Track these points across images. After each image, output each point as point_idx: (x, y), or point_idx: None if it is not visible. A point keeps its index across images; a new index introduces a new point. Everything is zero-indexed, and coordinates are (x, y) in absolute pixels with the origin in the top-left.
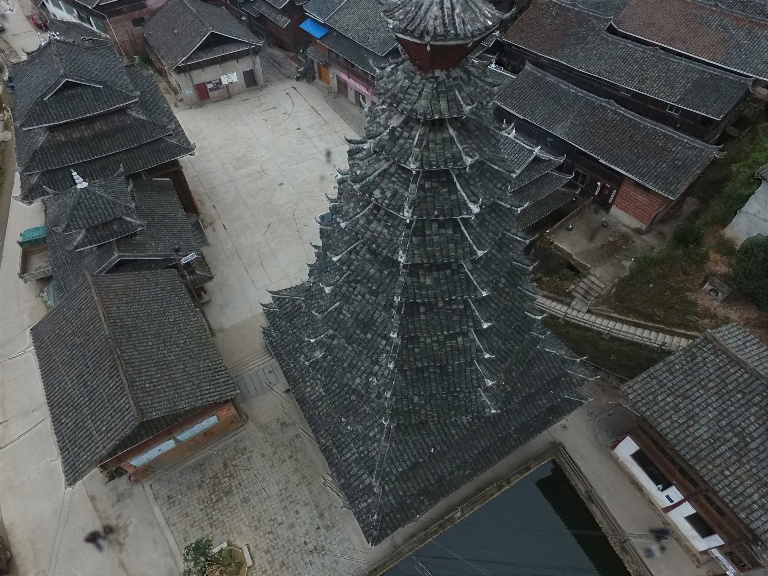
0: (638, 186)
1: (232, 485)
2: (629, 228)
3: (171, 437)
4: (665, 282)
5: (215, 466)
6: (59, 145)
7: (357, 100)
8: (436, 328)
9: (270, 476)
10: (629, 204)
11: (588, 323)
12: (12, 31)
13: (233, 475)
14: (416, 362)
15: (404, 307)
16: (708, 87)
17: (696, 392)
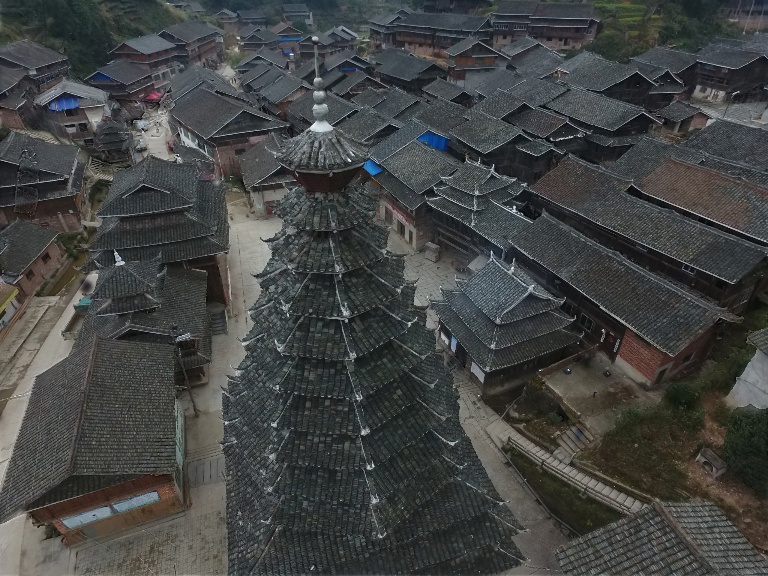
0: (640, 338)
1: (149, 572)
2: (634, 382)
3: (108, 504)
4: (651, 444)
5: (142, 547)
6: (123, 232)
7: (399, 228)
8: (316, 426)
9: (188, 572)
10: (633, 356)
11: (565, 476)
12: (151, 151)
13: (154, 562)
14: (298, 459)
15: (291, 399)
16: (722, 251)
17: (635, 573)
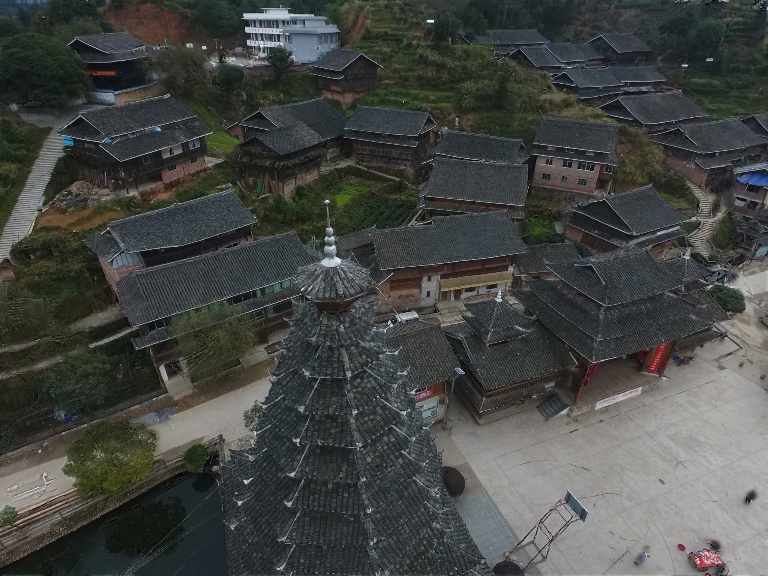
0: None
1: None
2: None
3: None
4: None
5: None
6: (553, 288)
7: None
8: None
9: None
10: None
11: None
12: None
13: None
14: None
15: None
16: None
17: None
